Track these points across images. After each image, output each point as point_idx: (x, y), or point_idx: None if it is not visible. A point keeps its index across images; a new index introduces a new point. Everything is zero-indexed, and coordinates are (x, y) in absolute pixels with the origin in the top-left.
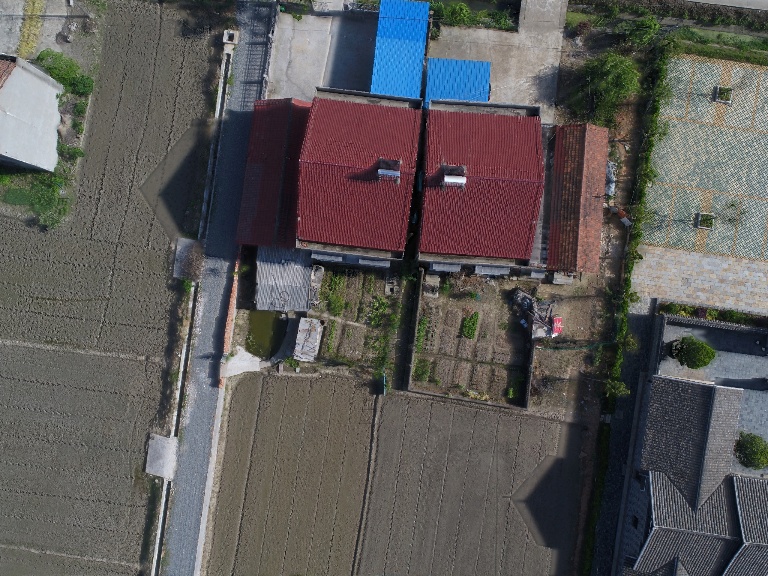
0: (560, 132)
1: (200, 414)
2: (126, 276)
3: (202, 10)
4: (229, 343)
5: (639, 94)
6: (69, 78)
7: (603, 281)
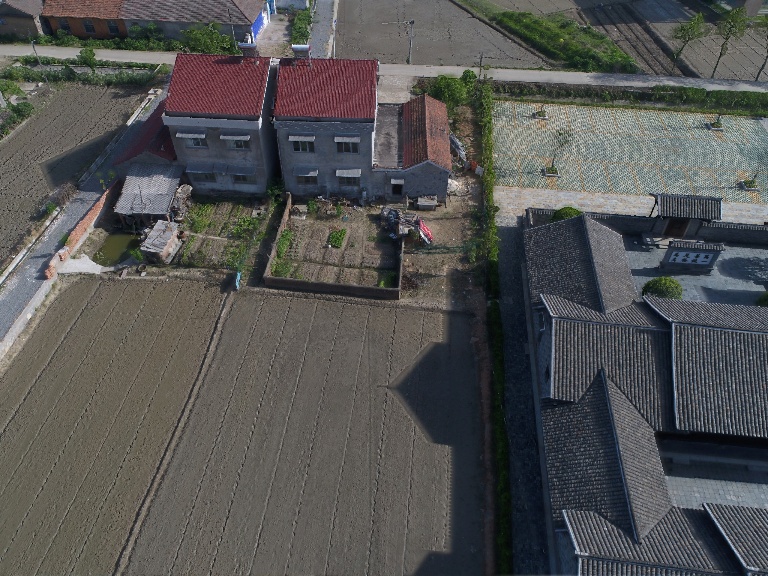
0: (406, 105)
1: (10, 303)
2: None
3: (139, 89)
4: (74, 245)
5: (475, 117)
6: (14, 105)
7: (468, 208)
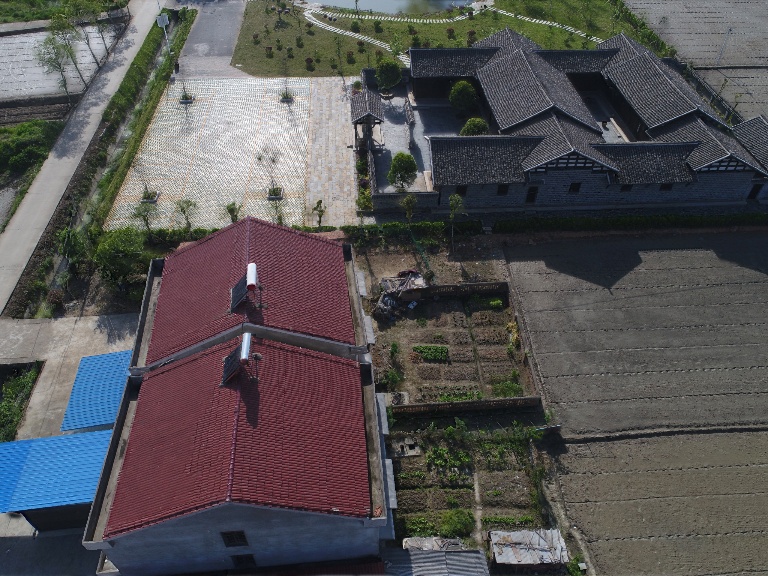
0: None
1: None
2: None
3: None
4: None
5: None
6: None
7: None
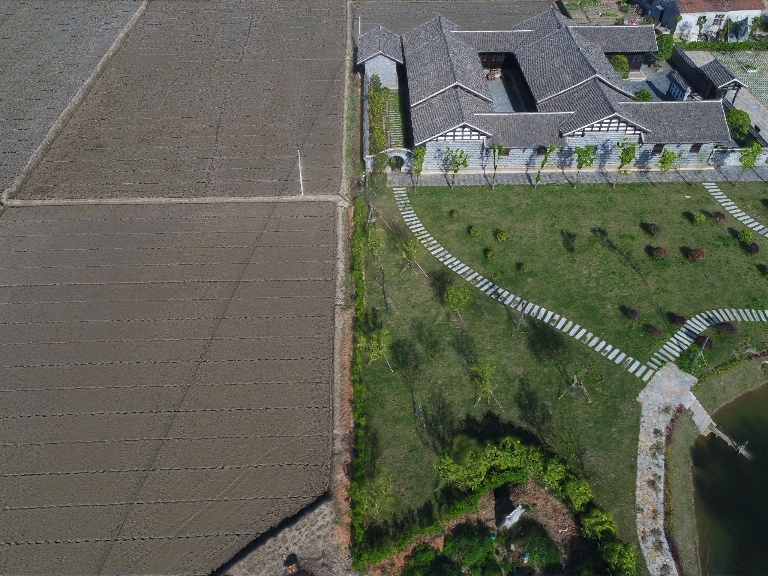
0: None
1: None
2: None
3: None
4: None
5: None
6: None
7: None
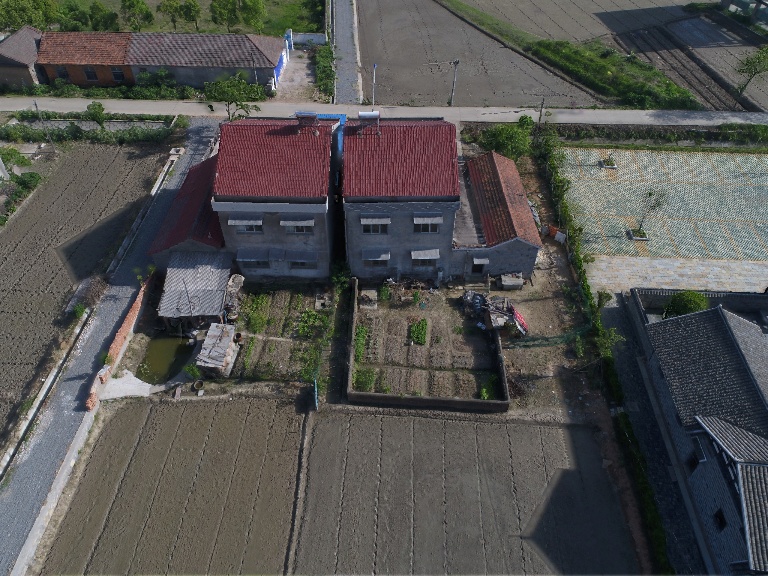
0: (471, 163)
1: (48, 446)
2: (7, 317)
3: (156, 146)
4: (115, 361)
5: (537, 168)
6: (18, 176)
7: (557, 285)
